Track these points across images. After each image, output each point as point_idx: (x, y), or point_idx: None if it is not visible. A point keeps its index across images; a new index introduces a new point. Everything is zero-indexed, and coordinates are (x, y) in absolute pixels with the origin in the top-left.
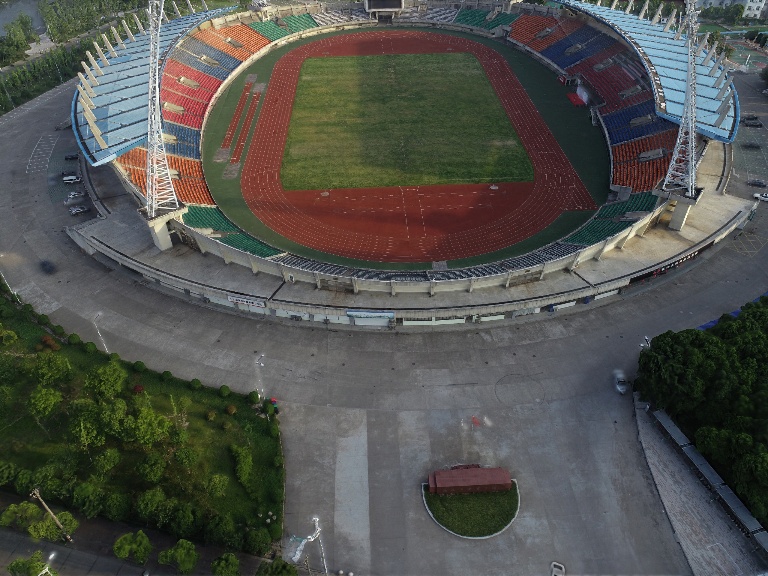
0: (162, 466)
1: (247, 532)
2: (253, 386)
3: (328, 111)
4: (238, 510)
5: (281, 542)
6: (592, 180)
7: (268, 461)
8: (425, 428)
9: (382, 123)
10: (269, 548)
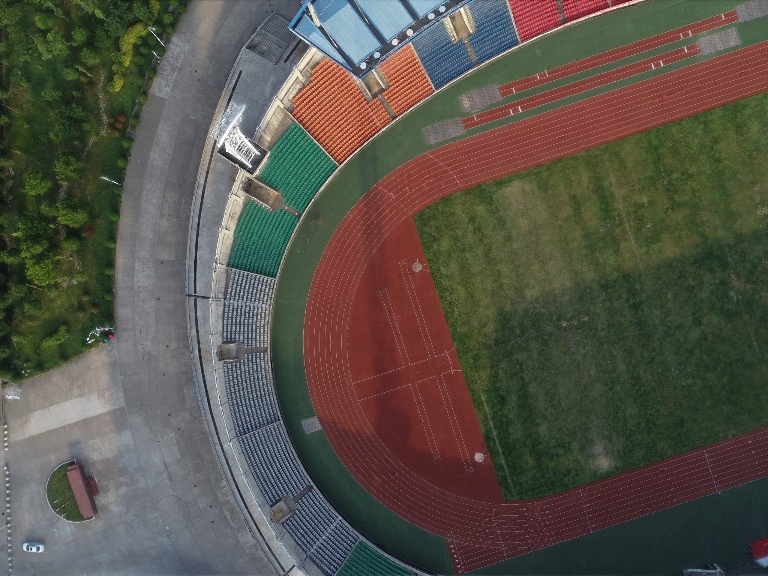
0: None
1: (1, 368)
2: (124, 313)
3: (650, 187)
4: (25, 350)
5: (14, 384)
6: (524, 568)
7: (63, 353)
8: (120, 452)
9: (625, 279)
10: (7, 379)
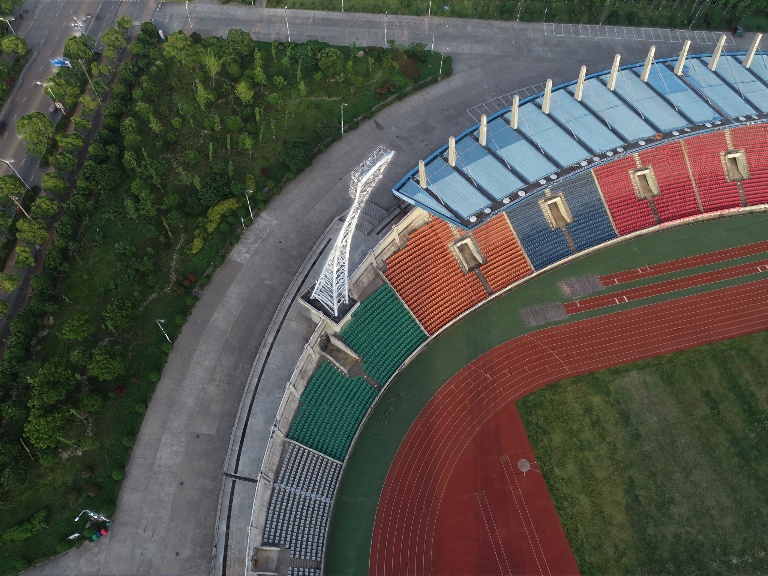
0: (3, 460)
1: None
2: (130, 500)
3: None
4: None
5: None
6: None
7: (28, 553)
8: None
9: None
10: None
